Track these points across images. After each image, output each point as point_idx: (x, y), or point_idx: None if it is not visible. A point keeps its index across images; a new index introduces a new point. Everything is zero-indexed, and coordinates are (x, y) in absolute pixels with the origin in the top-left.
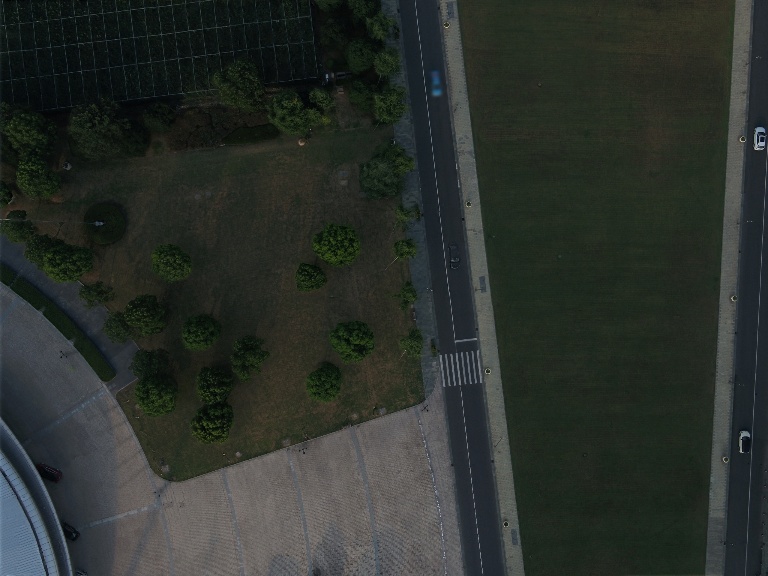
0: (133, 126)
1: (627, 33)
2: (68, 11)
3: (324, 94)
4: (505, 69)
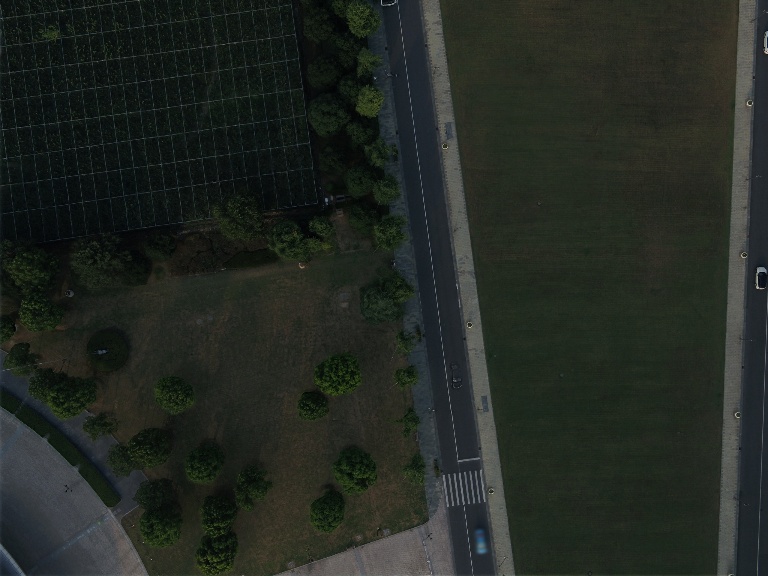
0: (134, 257)
1: (626, 151)
2: (68, 142)
3: (324, 224)
4: (504, 189)
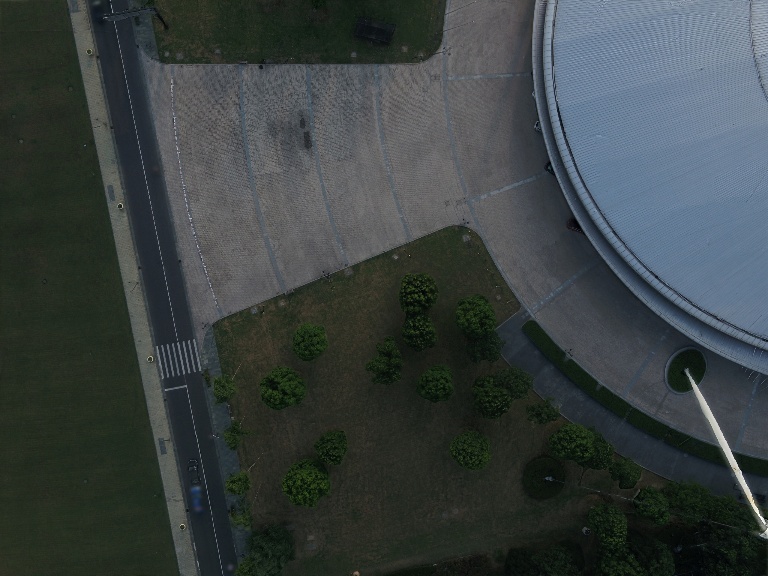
0: None
1: None
2: None
3: None
4: None
